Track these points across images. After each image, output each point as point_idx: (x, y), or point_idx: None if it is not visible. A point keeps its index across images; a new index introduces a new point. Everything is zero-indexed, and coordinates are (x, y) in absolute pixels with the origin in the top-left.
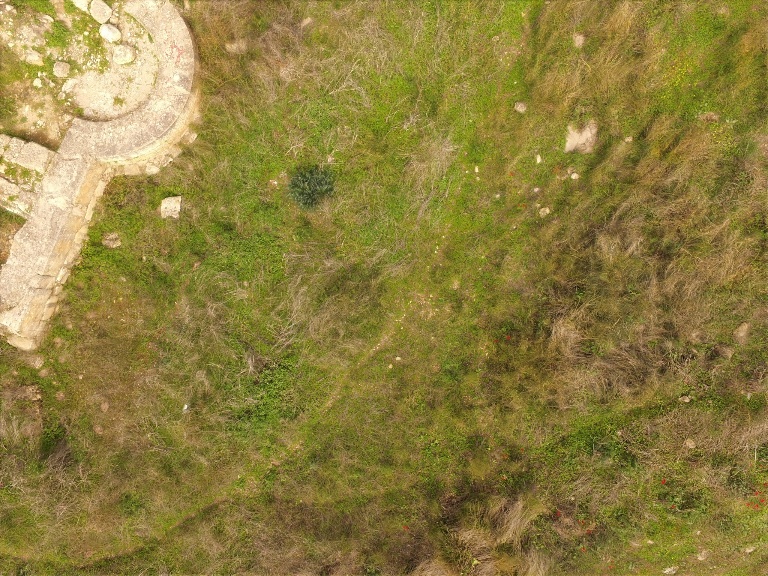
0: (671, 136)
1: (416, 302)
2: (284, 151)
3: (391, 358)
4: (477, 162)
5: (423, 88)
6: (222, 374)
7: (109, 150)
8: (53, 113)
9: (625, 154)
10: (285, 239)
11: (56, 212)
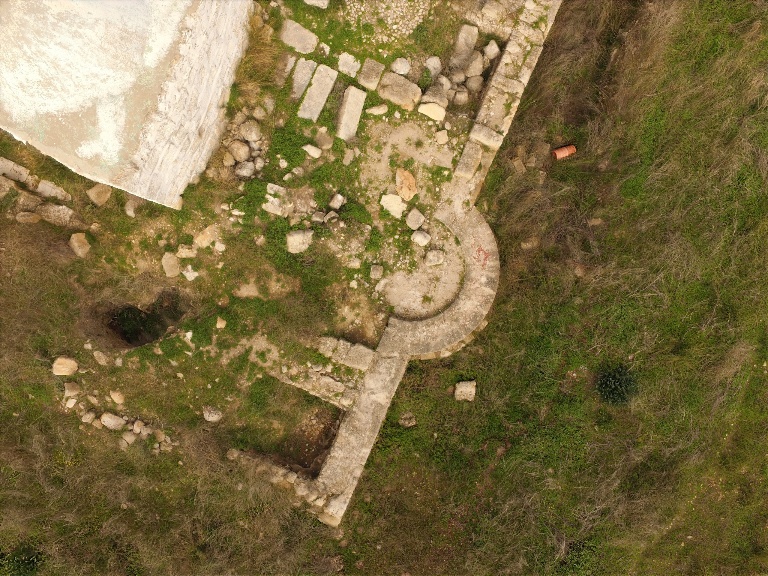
0: None
1: (706, 485)
2: (585, 347)
3: (683, 536)
4: (767, 358)
5: (719, 292)
6: (531, 555)
7: (423, 348)
8: (368, 312)
9: None
10: (587, 429)
11: (377, 407)
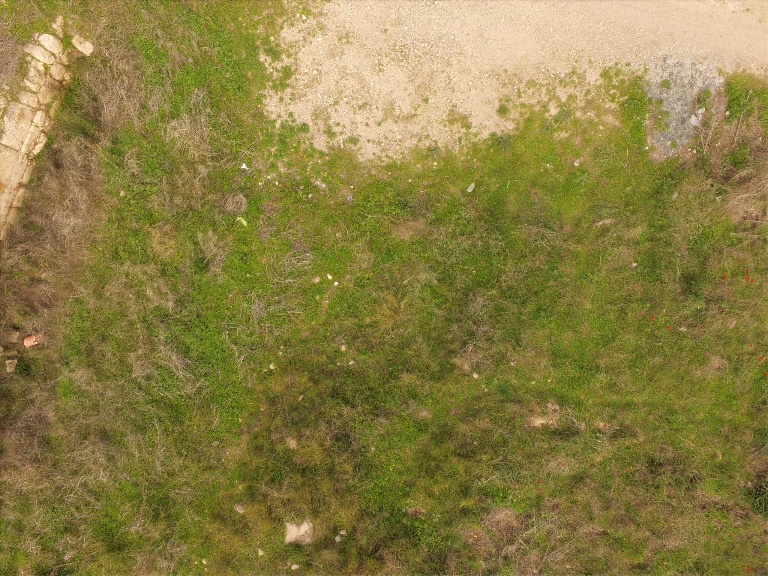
0: (372, 542)
1: None
2: (26, 548)
3: None
4: (203, 557)
5: (148, 494)
6: None
7: None
8: None
9: (331, 559)
10: None
11: None
